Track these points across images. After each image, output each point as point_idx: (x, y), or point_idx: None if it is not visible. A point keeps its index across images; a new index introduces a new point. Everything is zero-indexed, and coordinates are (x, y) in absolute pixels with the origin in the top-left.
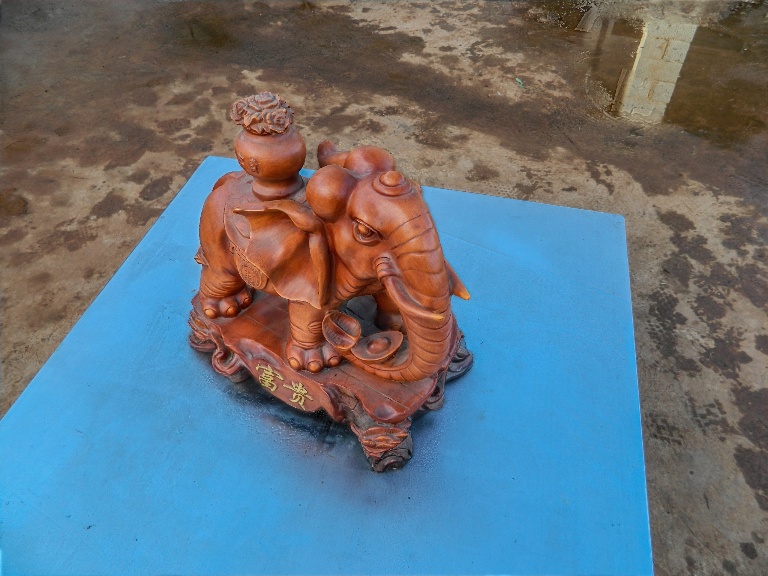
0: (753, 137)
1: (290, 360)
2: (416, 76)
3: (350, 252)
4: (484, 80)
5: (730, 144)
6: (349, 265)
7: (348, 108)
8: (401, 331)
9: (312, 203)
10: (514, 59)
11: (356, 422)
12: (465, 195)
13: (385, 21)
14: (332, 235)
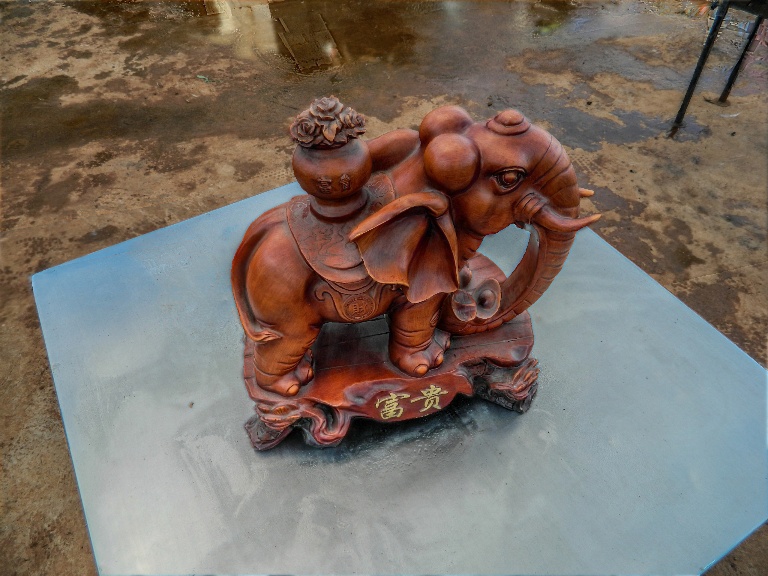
0: (414, 48)
1: (416, 370)
2: (96, 113)
3: (490, 210)
4: (169, 89)
5: (405, 59)
6: (484, 226)
7: (52, 175)
8: (460, 287)
9: (452, 179)
10: (179, 60)
11: (494, 382)
12: None
13: (4, 73)
14: (460, 206)
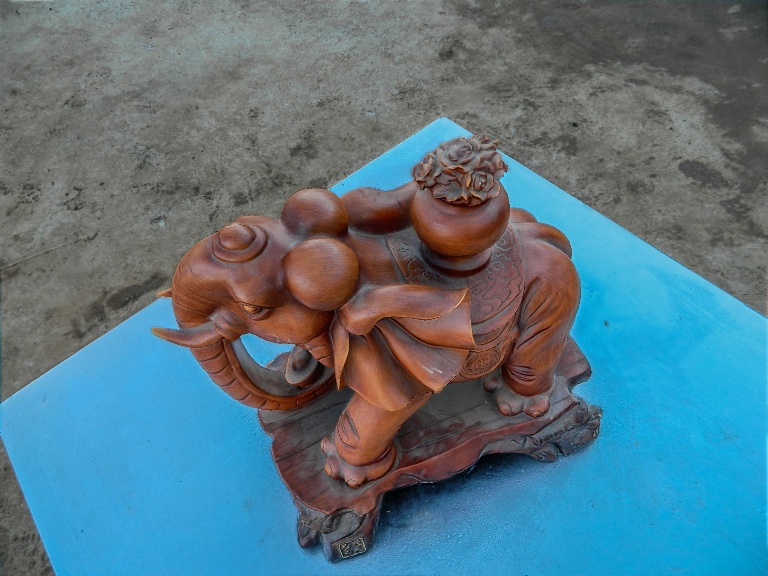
0: None
1: None
2: None
3: None
4: None
5: None
6: None
7: None
8: None
9: None
10: None
11: None
12: None
13: None
14: None
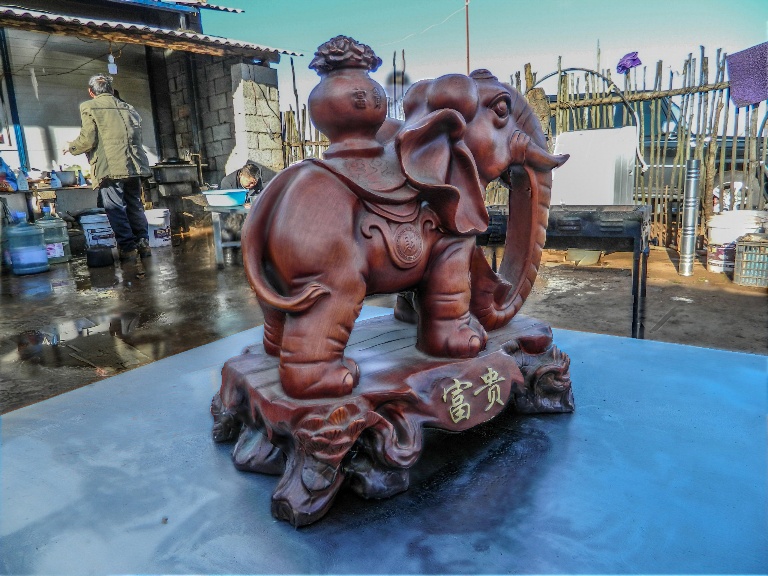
0: None
1: (471, 343)
2: None
3: (495, 140)
4: None
5: None
6: (491, 161)
7: None
8: None
9: (466, 94)
10: None
11: None
12: (232, 336)
13: None
14: (470, 137)
